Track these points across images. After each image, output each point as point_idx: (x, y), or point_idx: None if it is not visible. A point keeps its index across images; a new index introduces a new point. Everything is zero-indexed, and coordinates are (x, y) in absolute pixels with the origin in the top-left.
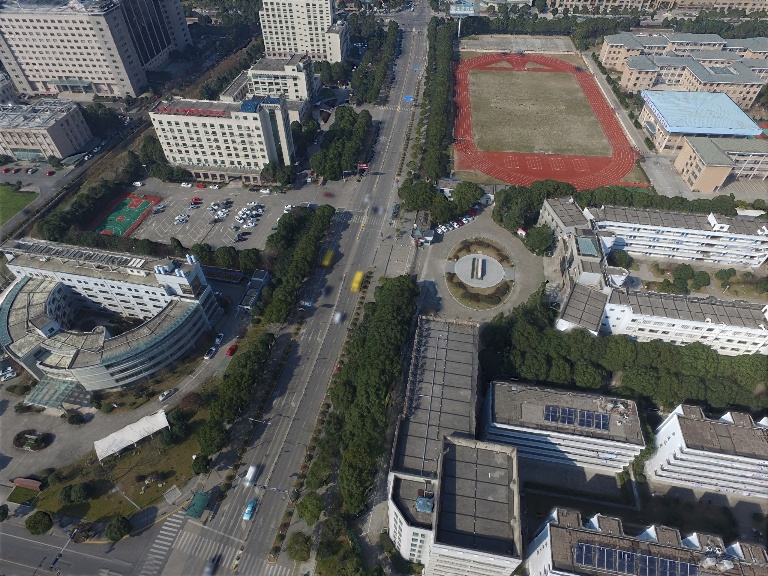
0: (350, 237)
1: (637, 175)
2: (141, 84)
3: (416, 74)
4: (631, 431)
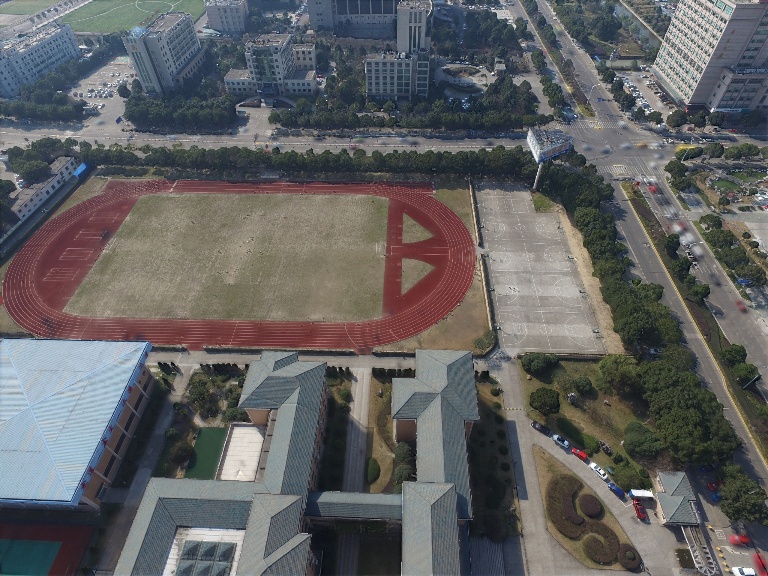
0: (47, 132)
1: (1, 327)
2: (323, 24)
3: (368, 152)
4: None
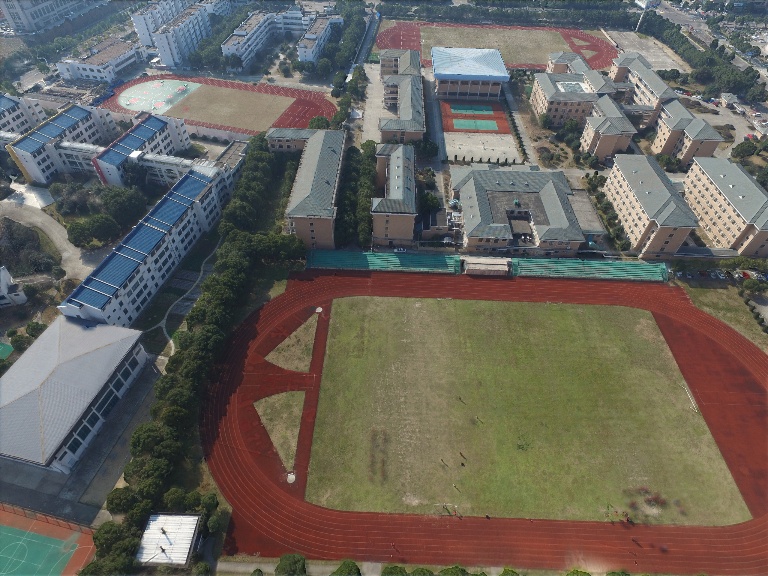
0: (333, 3)
1: None
2: None
3: None
4: (202, 3)
